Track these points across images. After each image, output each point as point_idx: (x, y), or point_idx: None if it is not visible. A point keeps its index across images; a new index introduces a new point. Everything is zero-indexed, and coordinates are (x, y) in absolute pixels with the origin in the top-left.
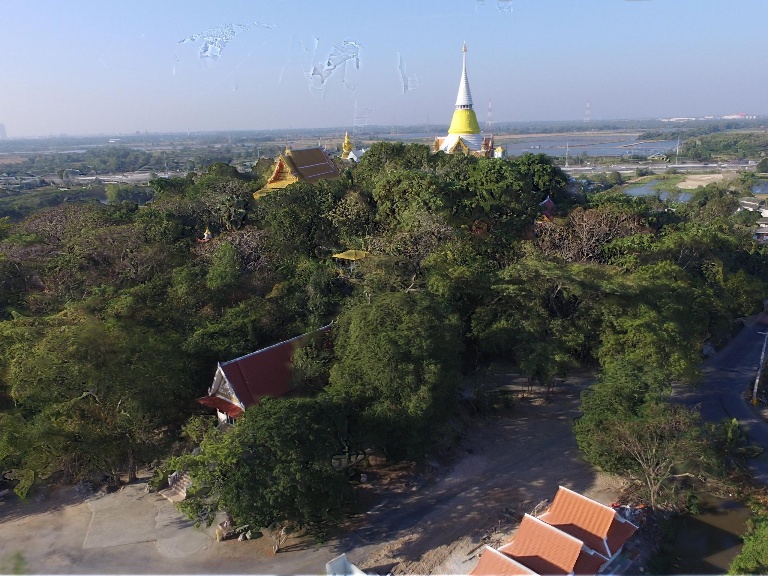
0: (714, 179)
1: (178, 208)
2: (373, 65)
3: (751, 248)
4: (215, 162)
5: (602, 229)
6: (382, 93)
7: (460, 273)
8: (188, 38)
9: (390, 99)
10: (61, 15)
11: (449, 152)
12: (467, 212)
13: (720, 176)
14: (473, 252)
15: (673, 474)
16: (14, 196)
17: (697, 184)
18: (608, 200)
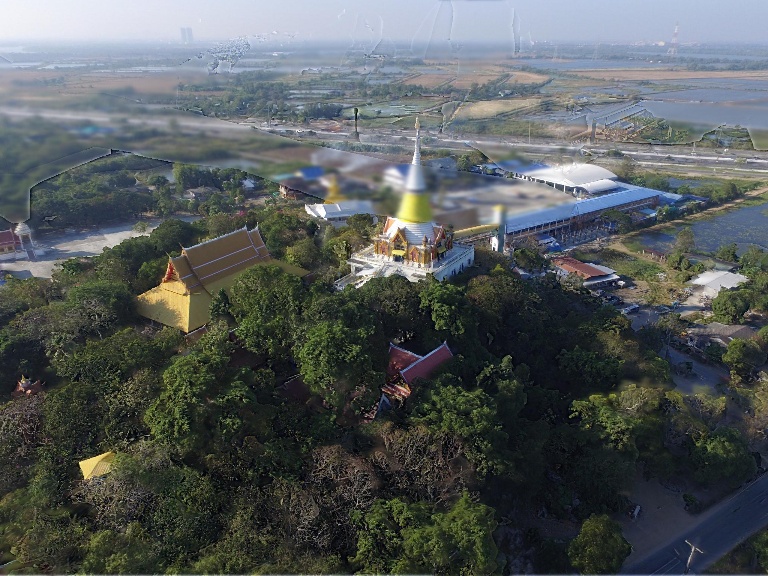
0: None
1: (32, 330)
2: (483, 22)
3: (699, 438)
4: (325, 111)
5: (394, 466)
6: (489, 54)
7: (114, 567)
8: (195, 56)
9: (498, 61)
10: (116, 6)
11: (389, 242)
12: (224, 435)
13: None
14: (207, 493)
15: None
16: (108, 158)
17: None
18: (445, 406)
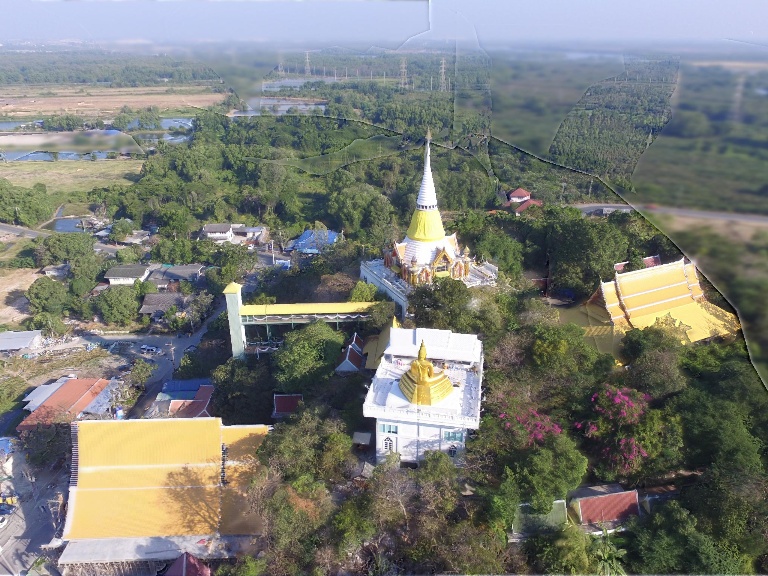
0: None
1: None
2: None
3: None
4: None
5: None
6: None
7: None
8: None
9: None
10: None
11: None
12: None
13: None
14: None
15: None
16: None
17: None
18: None
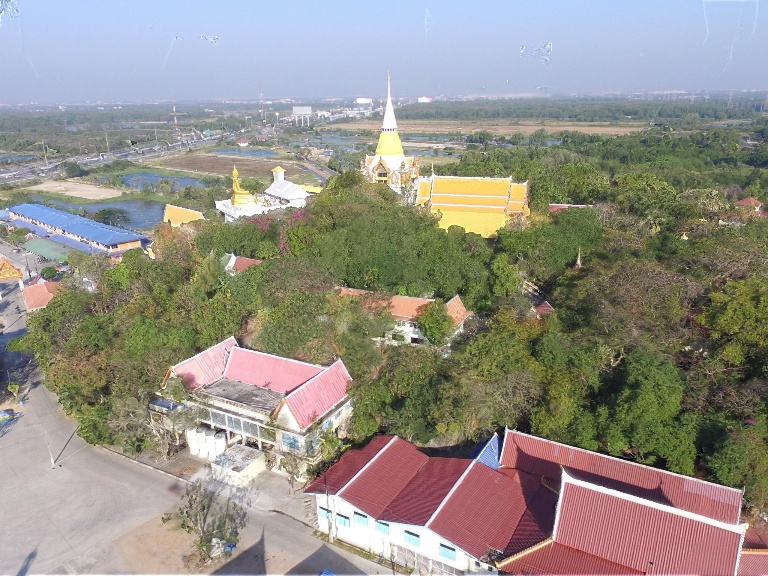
0: (73, 188)
1: None
2: None
3: None
4: None
5: None
6: None
7: None
8: None
9: None
10: None
11: (410, 170)
12: None
13: (58, 185)
14: None
15: None
16: None
17: (91, 193)
18: None
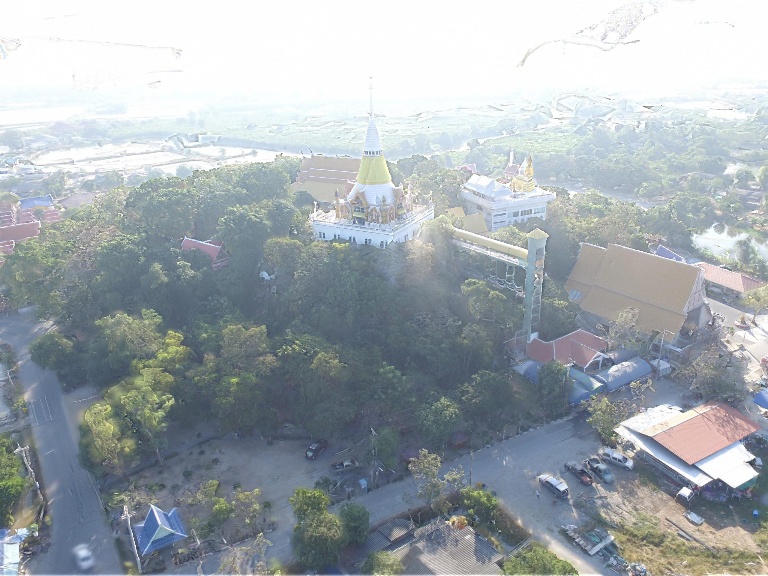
0: None
1: None
2: None
3: None
4: None
5: None
6: None
7: None
8: (588, 27)
9: None
10: None
11: None
12: None
13: None
14: None
15: (8, 310)
16: None
17: None
18: None
